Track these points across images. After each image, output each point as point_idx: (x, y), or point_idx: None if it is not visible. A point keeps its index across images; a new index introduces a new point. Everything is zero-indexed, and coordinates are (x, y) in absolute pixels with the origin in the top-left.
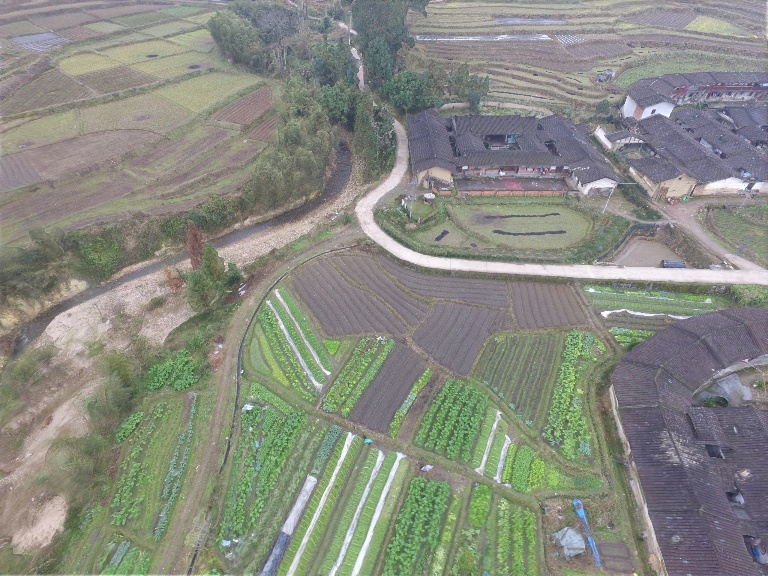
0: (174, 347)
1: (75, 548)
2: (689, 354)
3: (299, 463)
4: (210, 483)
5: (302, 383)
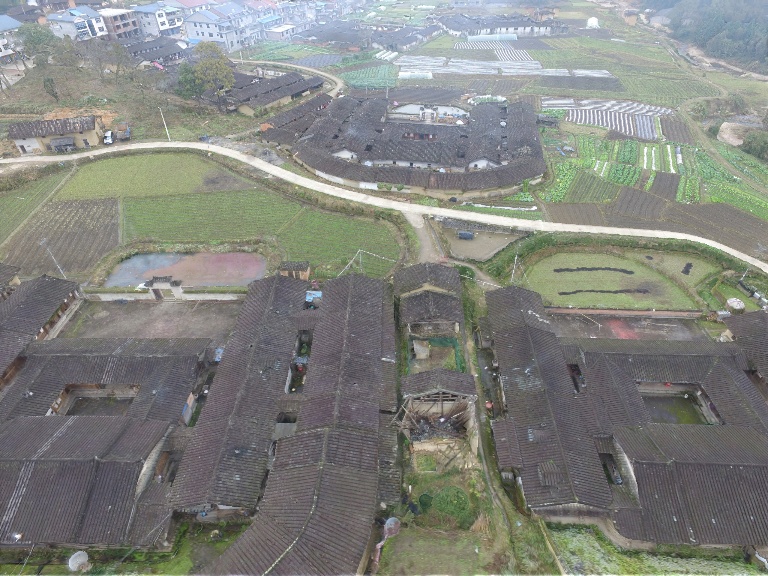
0: None
1: (759, 162)
2: None
3: None
4: None
5: None
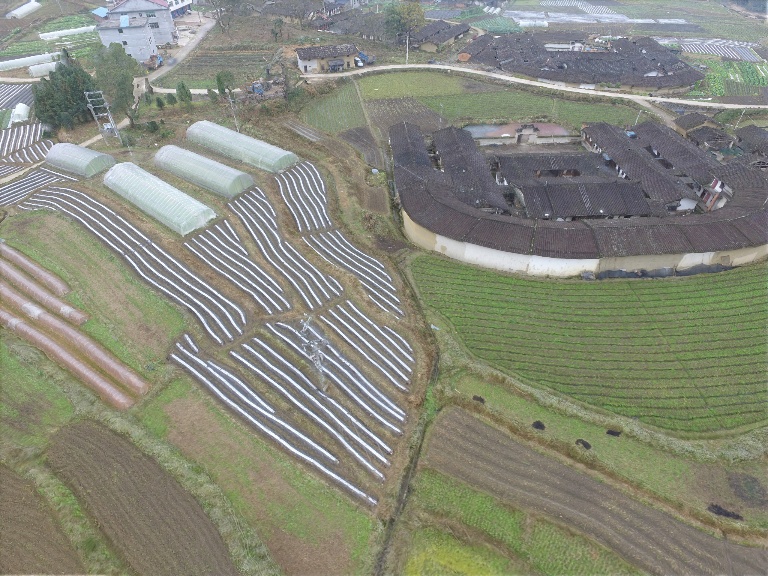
0: None
1: None
2: None
3: None
4: None
5: None
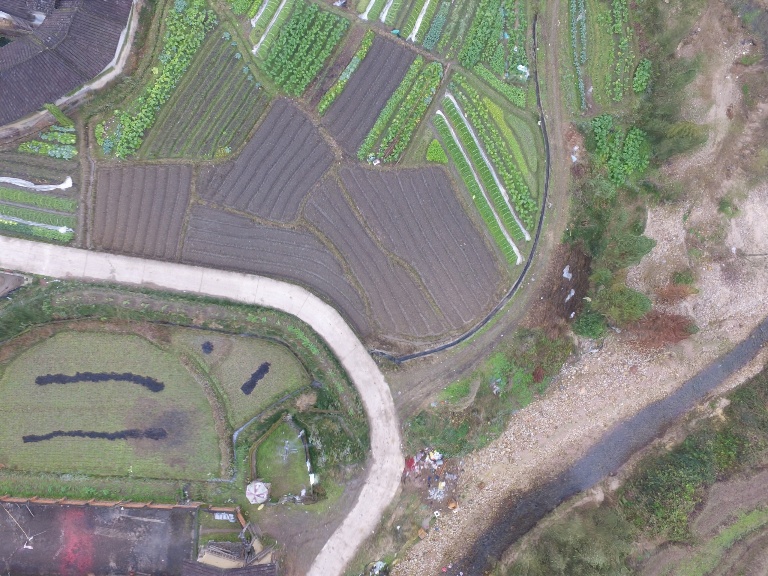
0: (632, 198)
1: None
2: (3, 66)
3: (463, 8)
4: (543, 8)
5: (468, 98)
